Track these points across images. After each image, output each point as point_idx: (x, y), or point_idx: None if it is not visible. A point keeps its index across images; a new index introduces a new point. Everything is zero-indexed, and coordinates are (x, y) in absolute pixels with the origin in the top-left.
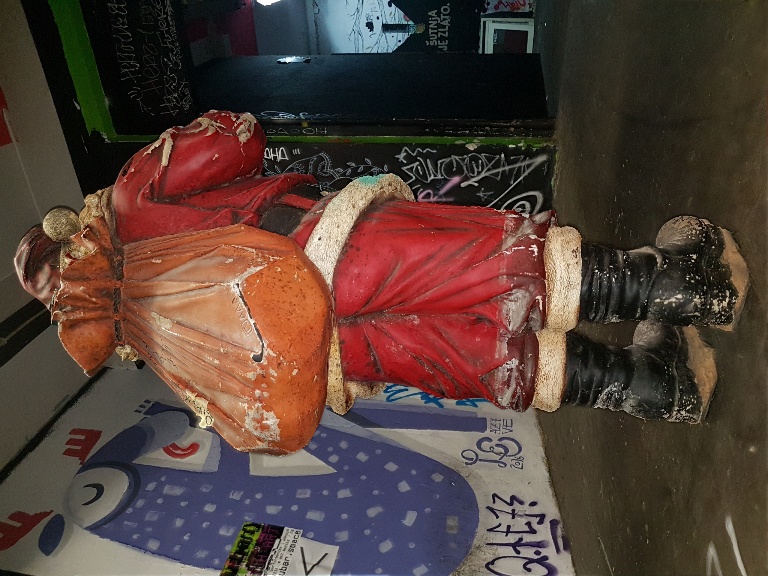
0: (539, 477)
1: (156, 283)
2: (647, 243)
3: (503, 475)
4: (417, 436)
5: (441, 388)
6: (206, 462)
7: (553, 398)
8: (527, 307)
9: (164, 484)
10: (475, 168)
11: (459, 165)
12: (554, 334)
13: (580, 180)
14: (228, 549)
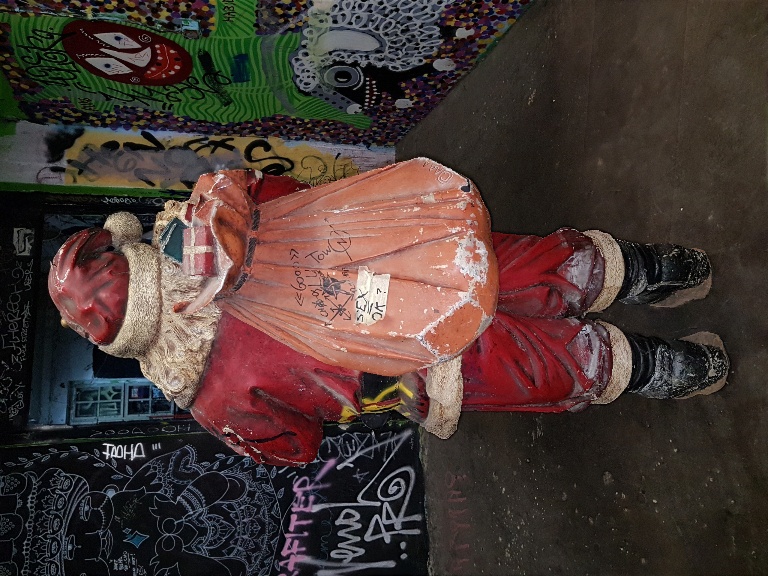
0: None
1: (316, 190)
2: None
3: None
4: None
5: (532, 372)
6: None
7: (628, 356)
8: (592, 258)
9: None
10: (349, 448)
11: (333, 446)
12: (598, 321)
13: (462, 415)
14: None
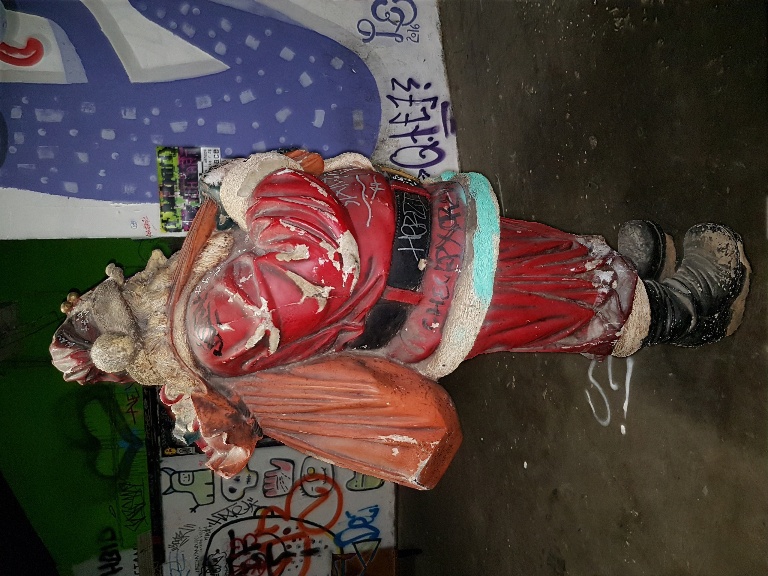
0: (433, 51)
1: (315, 451)
2: (673, 96)
3: (400, 53)
4: (307, 4)
5: None
6: (66, 70)
7: None
8: None
9: (31, 108)
10: None
11: None
12: None
13: None
14: (154, 181)
